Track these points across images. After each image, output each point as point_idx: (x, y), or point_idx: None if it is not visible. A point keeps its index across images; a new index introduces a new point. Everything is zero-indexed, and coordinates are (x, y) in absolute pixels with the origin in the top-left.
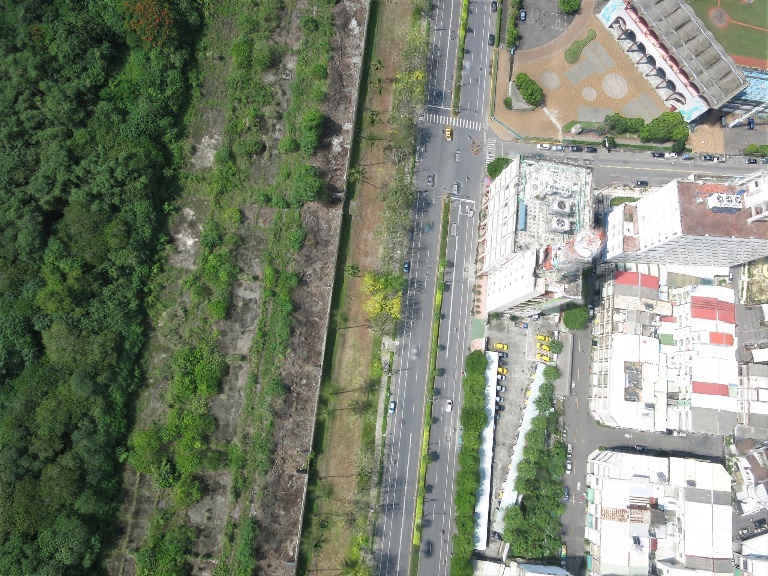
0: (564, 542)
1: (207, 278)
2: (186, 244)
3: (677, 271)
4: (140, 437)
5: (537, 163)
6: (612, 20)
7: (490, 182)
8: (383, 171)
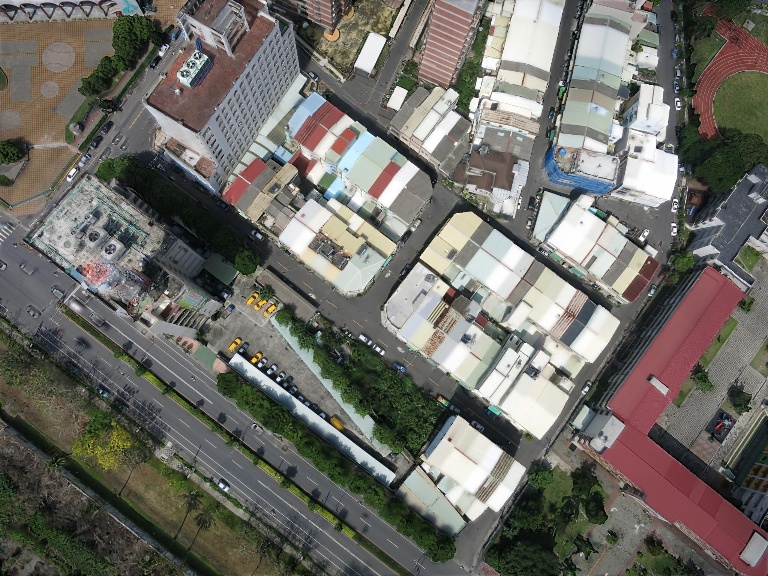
0: (437, 395)
1: None
2: None
3: (272, 127)
4: None
5: (44, 226)
6: None
7: None
8: None
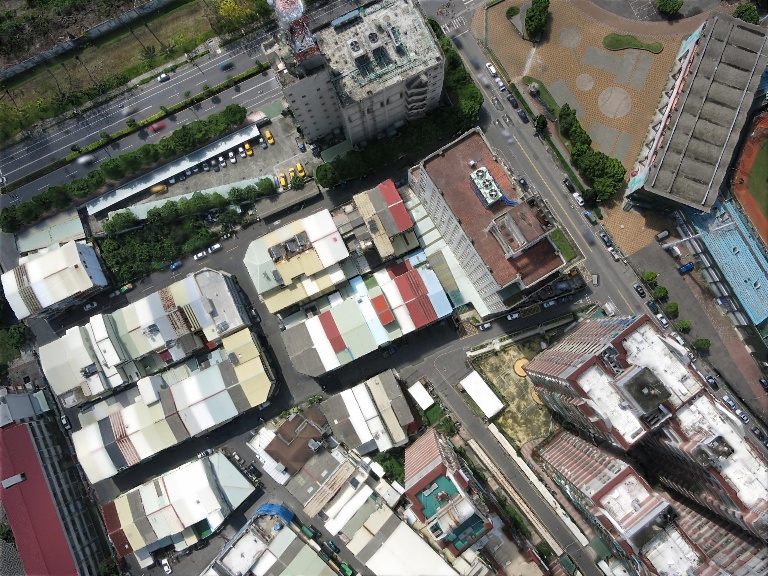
0: (136, 286)
1: None
2: None
3: (448, 260)
4: None
5: (413, 7)
6: (684, 51)
7: None
8: None
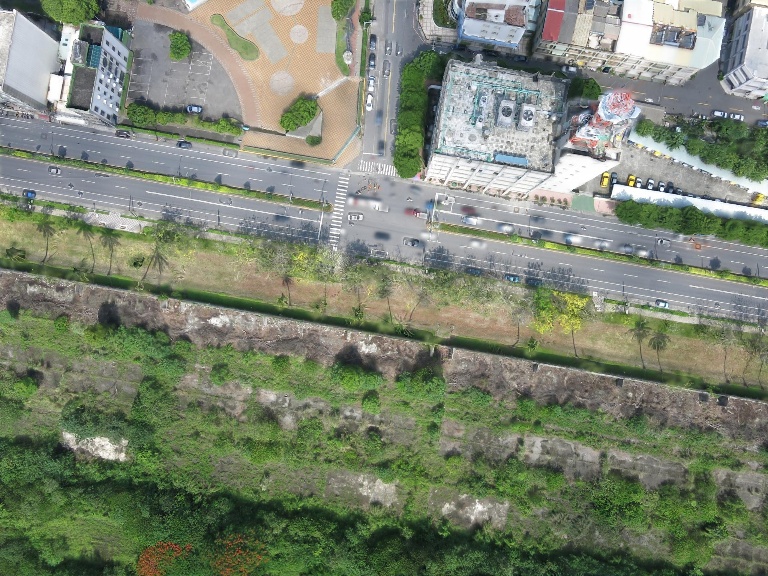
0: None
1: (523, 493)
2: (482, 512)
3: None
4: (681, 557)
5: (442, 132)
6: None
7: (417, 174)
8: (410, 302)
